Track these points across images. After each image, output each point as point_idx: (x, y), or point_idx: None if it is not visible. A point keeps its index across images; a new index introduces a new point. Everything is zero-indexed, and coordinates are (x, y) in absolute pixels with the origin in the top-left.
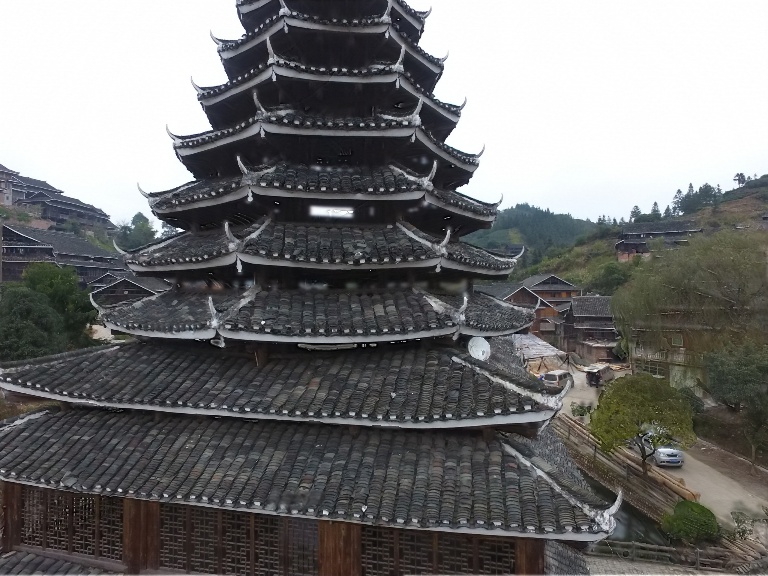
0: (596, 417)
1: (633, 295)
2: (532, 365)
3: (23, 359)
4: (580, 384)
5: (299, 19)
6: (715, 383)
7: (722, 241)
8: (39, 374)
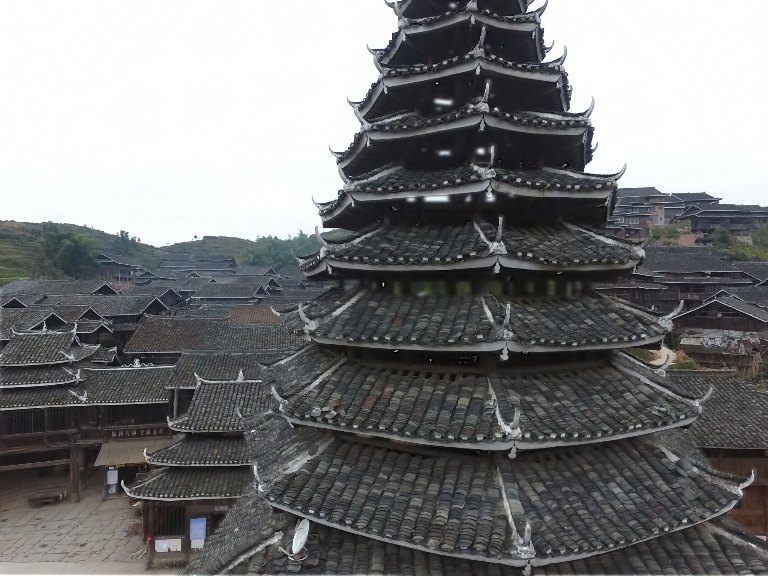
0: None
1: None
2: None
3: None
4: None
5: None
6: None
7: None
8: None
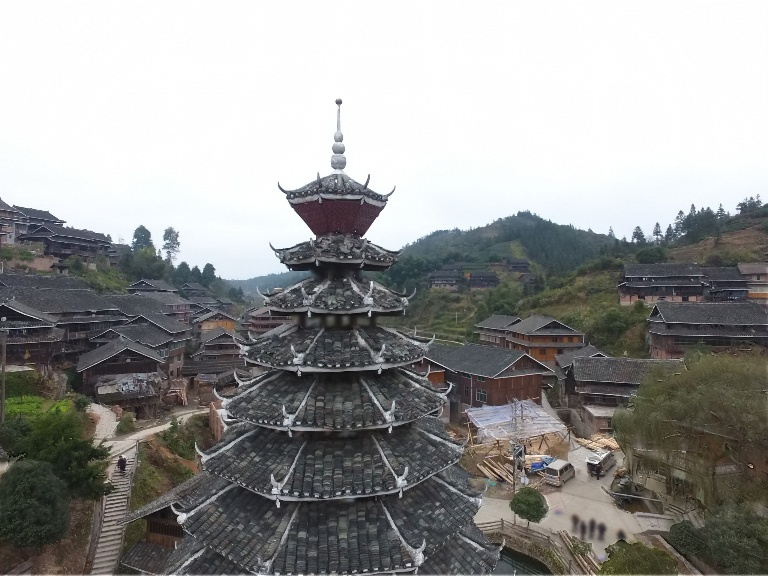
0: None
1: (635, 422)
2: (533, 444)
3: (27, 540)
4: (581, 471)
5: (303, 426)
6: (716, 550)
7: (724, 372)
8: None
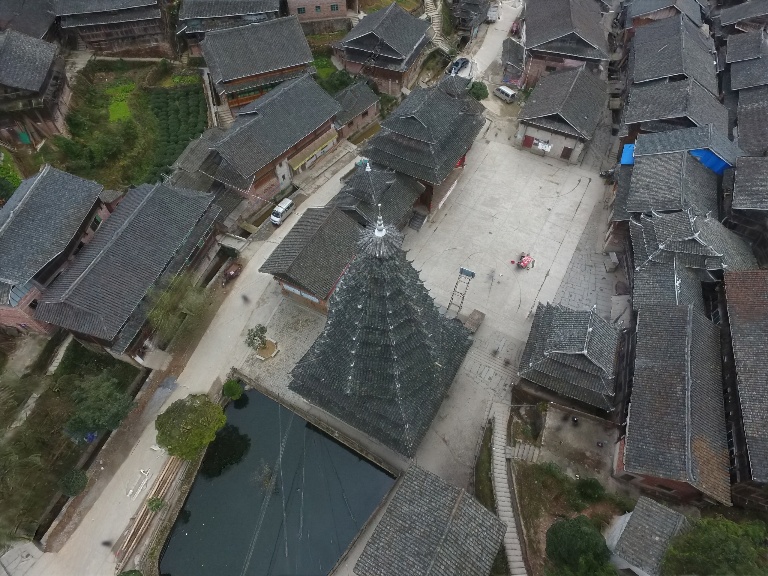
0: (215, 427)
1: None
2: None
3: None
4: None
5: None
6: None
7: None
8: (454, 323)
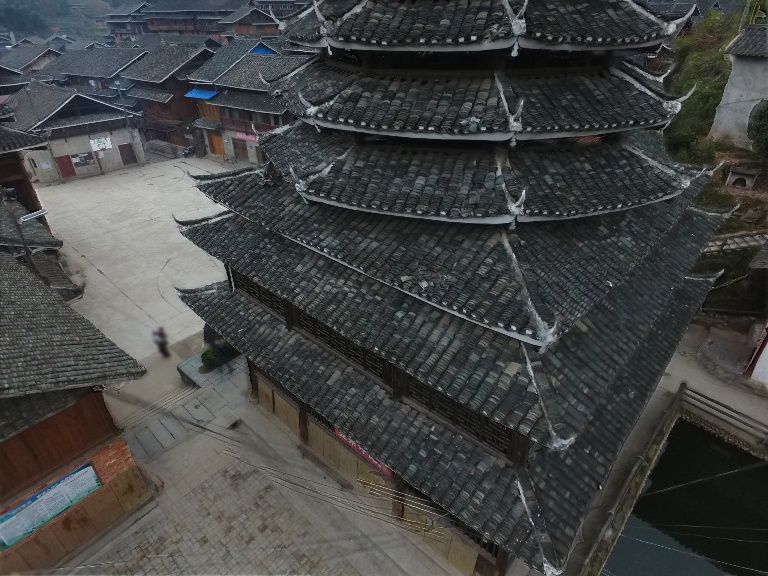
0: None
1: None
2: None
3: None
4: None
5: None
6: None
7: None
8: None
